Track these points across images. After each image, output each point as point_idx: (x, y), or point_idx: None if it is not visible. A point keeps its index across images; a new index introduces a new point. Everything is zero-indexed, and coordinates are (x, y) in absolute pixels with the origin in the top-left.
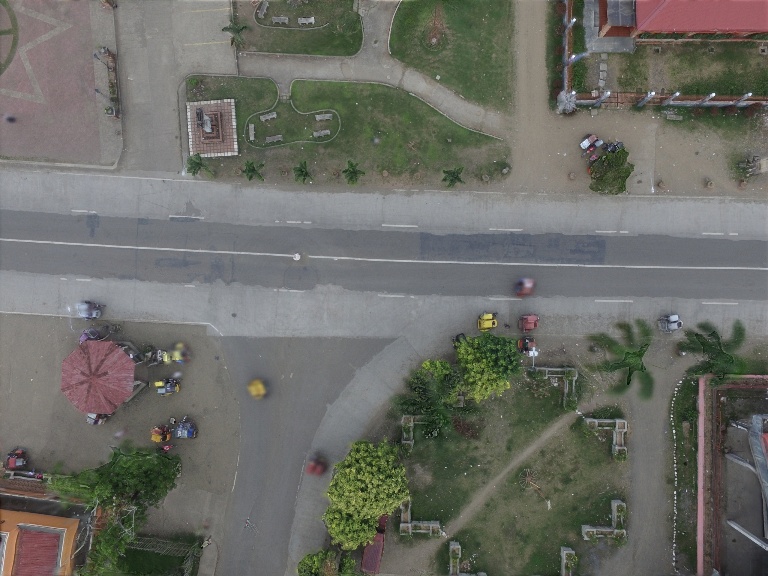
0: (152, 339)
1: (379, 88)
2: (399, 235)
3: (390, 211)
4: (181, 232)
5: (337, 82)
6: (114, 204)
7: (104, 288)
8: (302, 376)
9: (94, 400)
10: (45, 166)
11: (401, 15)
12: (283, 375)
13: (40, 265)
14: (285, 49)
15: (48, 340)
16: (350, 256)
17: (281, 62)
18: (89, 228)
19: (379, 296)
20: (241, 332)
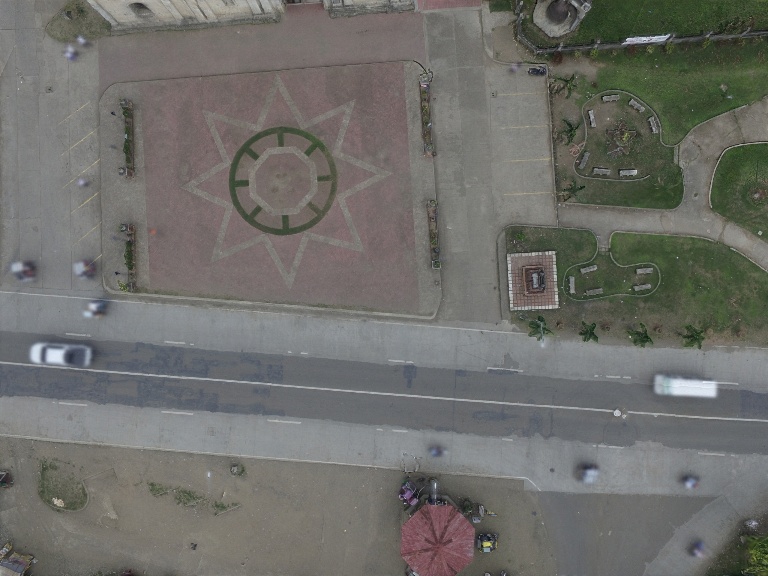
0: (468, 492)
1: (700, 242)
2: (720, 392)
3: (710, 367)
4: (499, 385)
5: (657, 235)
6: (432, 355)
7: (420, 440)
8: (621, 534)
9: (436, 567)
10: (362, 315)
11: (723, 169)
12: (601, 532)
13: (356, 415)
14: (605, 201)
15: (362, 491)
16: (670, 412)
17: (600, 213)
18: (406, 379)
19: (699, 454)
20: (559, 488)
